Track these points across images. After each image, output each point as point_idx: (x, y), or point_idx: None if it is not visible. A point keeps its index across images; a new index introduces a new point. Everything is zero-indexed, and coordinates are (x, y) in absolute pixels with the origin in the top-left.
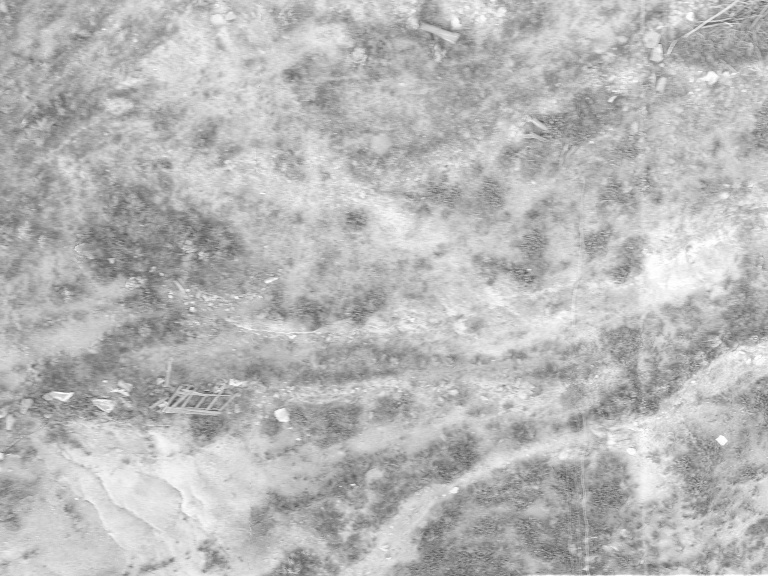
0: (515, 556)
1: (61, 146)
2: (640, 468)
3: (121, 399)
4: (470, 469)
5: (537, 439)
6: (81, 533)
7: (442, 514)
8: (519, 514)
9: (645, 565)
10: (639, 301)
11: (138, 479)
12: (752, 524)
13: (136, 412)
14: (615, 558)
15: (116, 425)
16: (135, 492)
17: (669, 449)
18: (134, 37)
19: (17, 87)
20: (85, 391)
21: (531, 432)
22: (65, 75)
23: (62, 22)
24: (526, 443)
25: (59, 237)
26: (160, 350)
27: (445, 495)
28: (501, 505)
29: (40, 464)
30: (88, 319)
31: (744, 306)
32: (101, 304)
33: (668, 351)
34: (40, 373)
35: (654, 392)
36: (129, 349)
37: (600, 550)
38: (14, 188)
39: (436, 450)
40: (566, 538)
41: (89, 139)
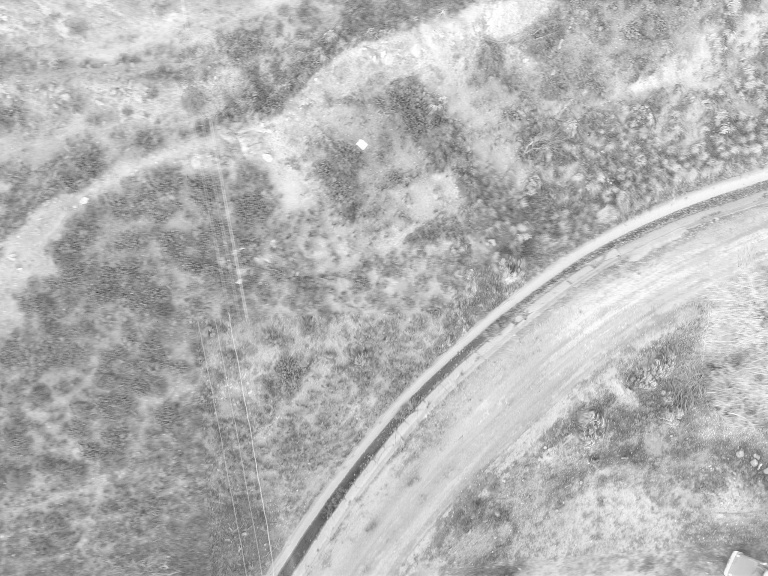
0: (163, 271)
1: None
2: (281, 176)
3: None
4: (97, 178)
5: (164, 145)
6: None
7: (76, 226)
8: (159, 226)
9: (302, 277)
10: (255, 4)
11: None
12: (410, 233)
13: None
14: (268, 270)
15: None
16: None
17: (308, 155)
18: None
19: None
20: None
21: (155, 138)
22: None
23: None
24: (153, 150)
25: None
26: None
27: (76, 206)
28: (140, 219)
29: None
30: None
31: (362, 2)
32: None
33: (289, 51)
34: None
35: (276, 91)
36: None
37: (251, 262)
38: None
39: (60, 160)
40: (213, 250)
41: None
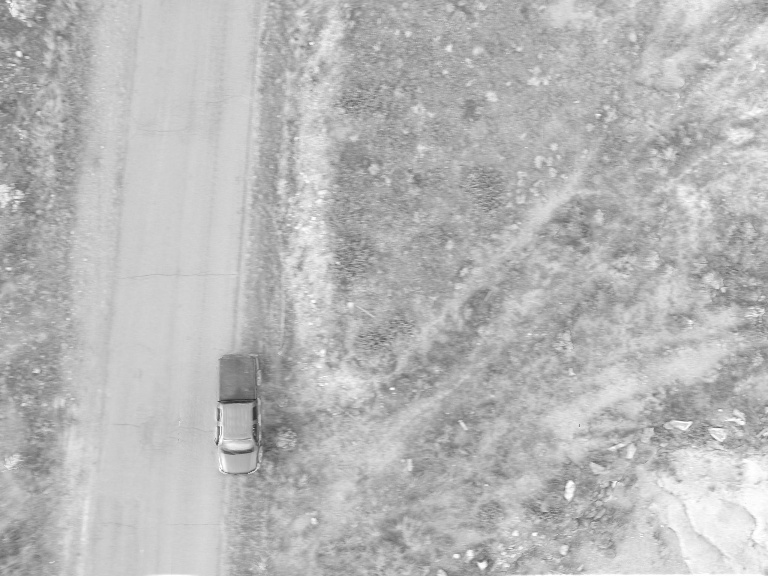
0: None
1: (681, 175)
2: None
3: (734, 428)
4: None
5: None
6: (663, 560)
7: None
8: None
9: None
10: None
11: (721, 506)
12: None
13: (743, 441)
14: None
15: (718, 453)
16: (718, 519)
17: None
18: (761, 67)
19: (642, 116)
20: (701, 420)
21: None
22: (687, 104)
23: (686, 52)
24: None
25: (676, 266)
26: (764, 379)
27: None
28: None
29: (636, 492)
30: (701, 348)
31: None
32: (713, 333)
33: None
34: (661, 402)
35: None
36: (739, 378)
37: None
38: (635, 217)
39: None
40: None
41: (710, 169)
